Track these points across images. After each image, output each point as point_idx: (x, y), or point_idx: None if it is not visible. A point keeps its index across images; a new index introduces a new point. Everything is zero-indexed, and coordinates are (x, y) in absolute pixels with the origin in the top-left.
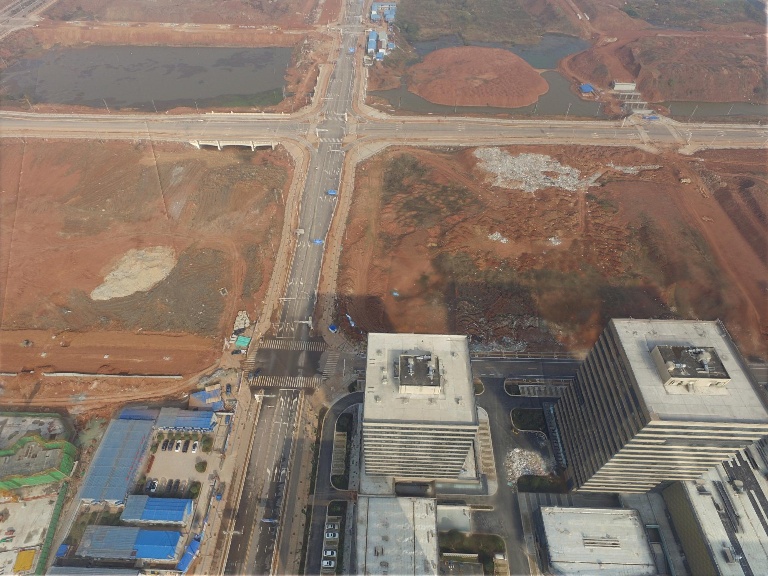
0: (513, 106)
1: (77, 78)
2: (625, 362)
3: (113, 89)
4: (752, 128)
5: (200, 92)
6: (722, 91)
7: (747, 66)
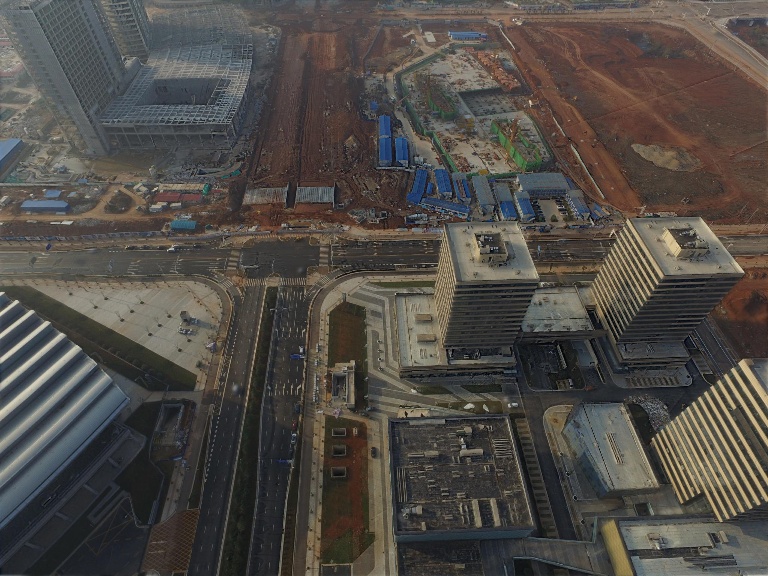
0: None
1: None
2: None
3: None
4: None
5: None
6: None
7: None
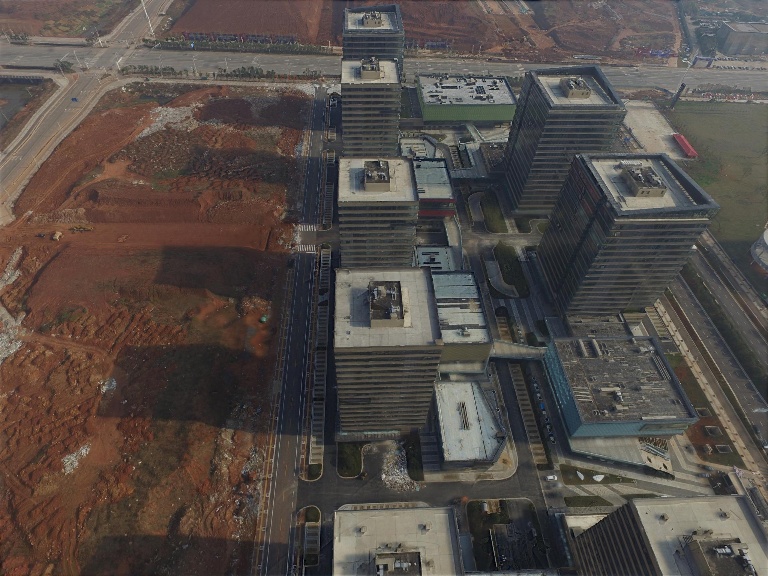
0: None
1: None
2: (383, 350)
3: None
4: (2, 160)
5: None
6: None
7: None
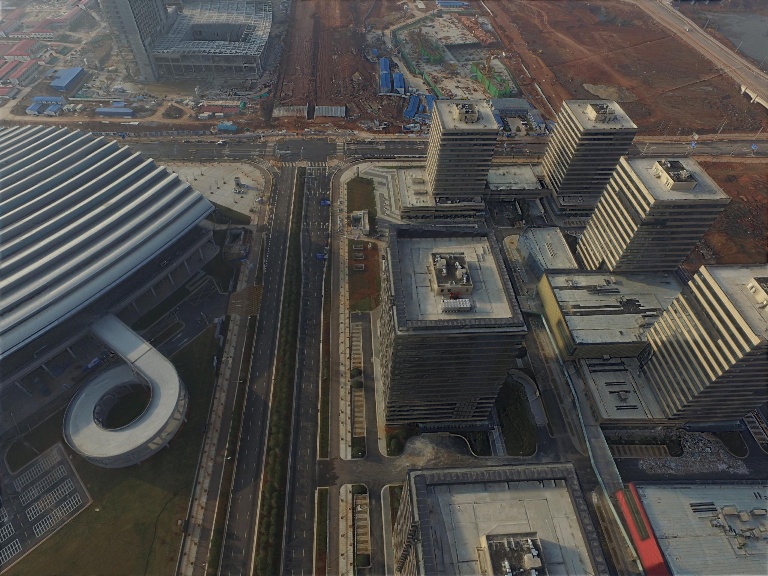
0: None
1: (760, 35)
2: None
3: (767, 50)
4: None
5: None
6: None
7: None
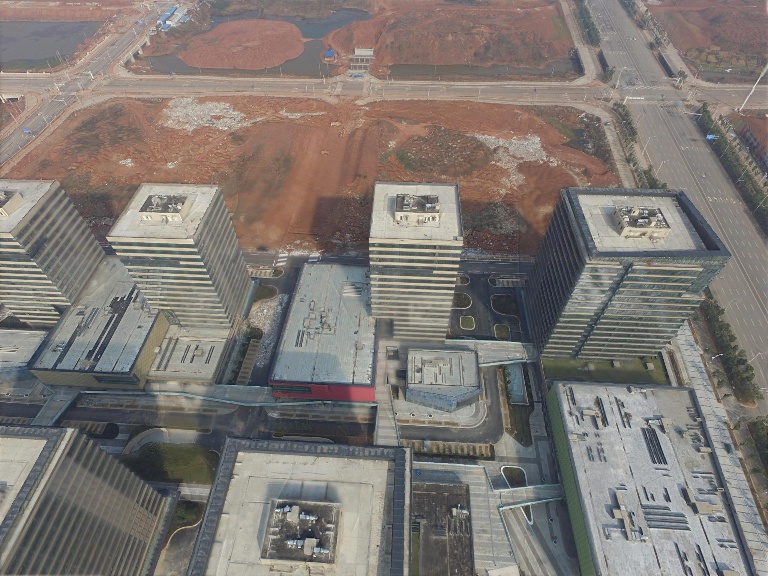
0: (255, 68)
1: None
2: None
3: None
4: (438, 84)
5: None
6: (445, 55)
7: (473, 33)
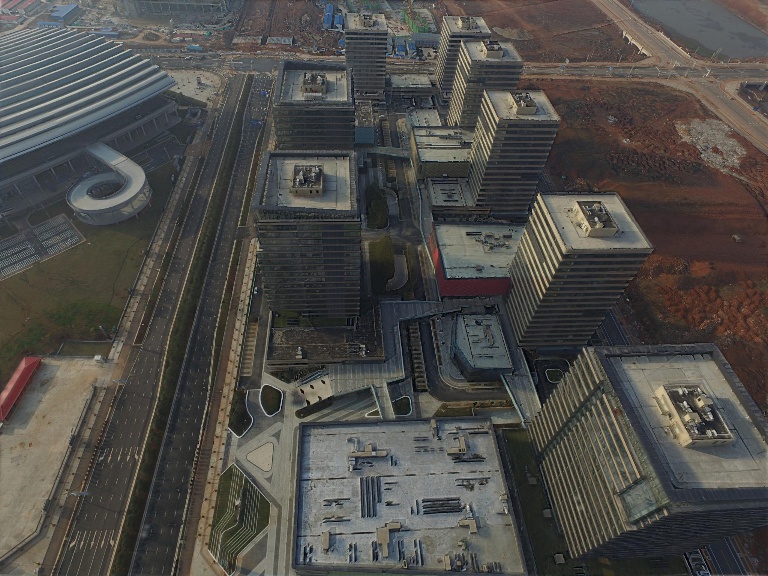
0: None
1: None
2: None
3: (660, 9)
4: None
5: (688, 32)
6: None
7: None
